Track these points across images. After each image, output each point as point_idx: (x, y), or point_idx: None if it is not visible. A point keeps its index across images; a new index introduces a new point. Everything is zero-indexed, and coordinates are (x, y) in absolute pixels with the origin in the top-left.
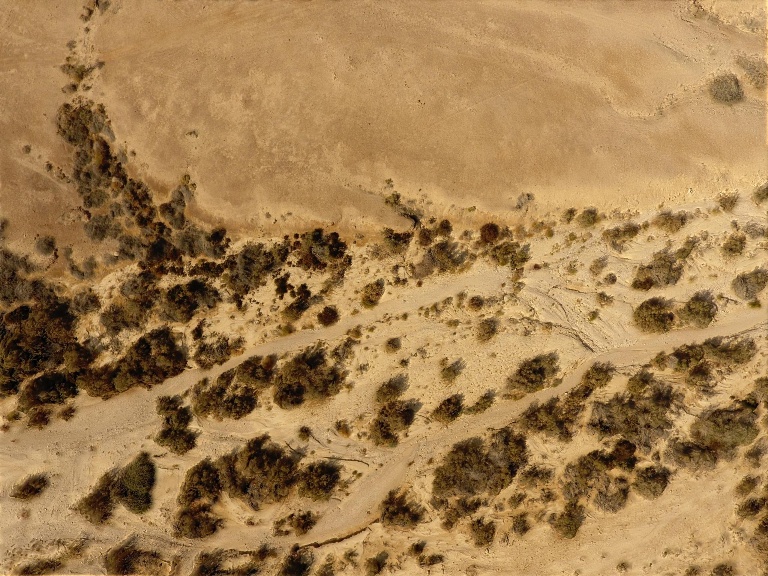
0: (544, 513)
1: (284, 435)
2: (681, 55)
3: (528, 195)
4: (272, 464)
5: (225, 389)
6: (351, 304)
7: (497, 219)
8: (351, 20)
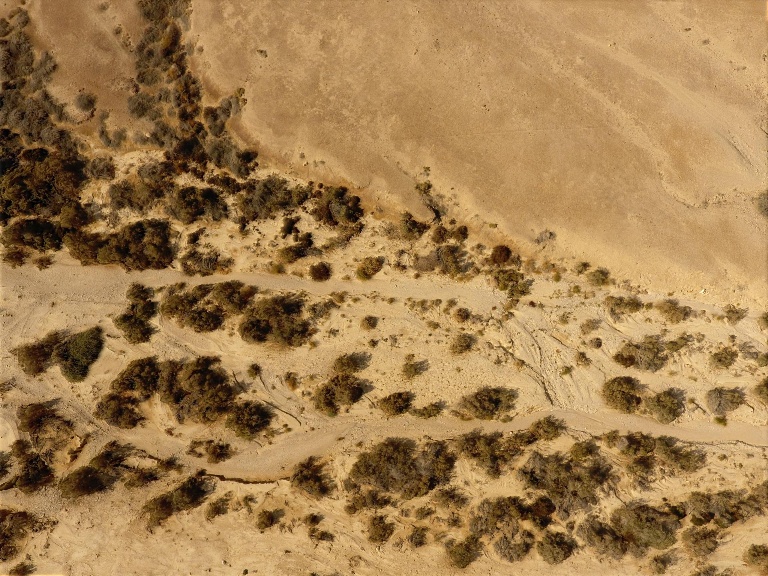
0: (445, 535)
1: (234, 365)
2: (746, 161)
3: (551, 234)
4: (212, 386)
5: (197, 300)
6: (345, 269)
7: (513, 245)
8: (452, 6)
